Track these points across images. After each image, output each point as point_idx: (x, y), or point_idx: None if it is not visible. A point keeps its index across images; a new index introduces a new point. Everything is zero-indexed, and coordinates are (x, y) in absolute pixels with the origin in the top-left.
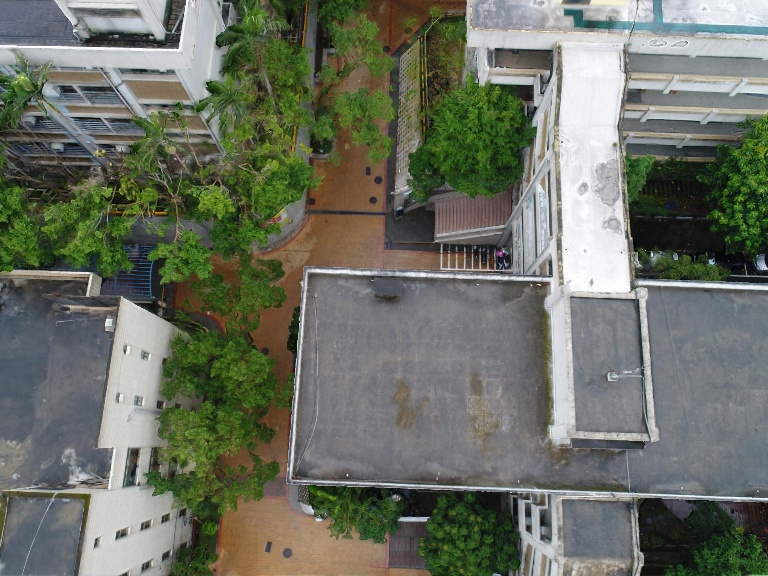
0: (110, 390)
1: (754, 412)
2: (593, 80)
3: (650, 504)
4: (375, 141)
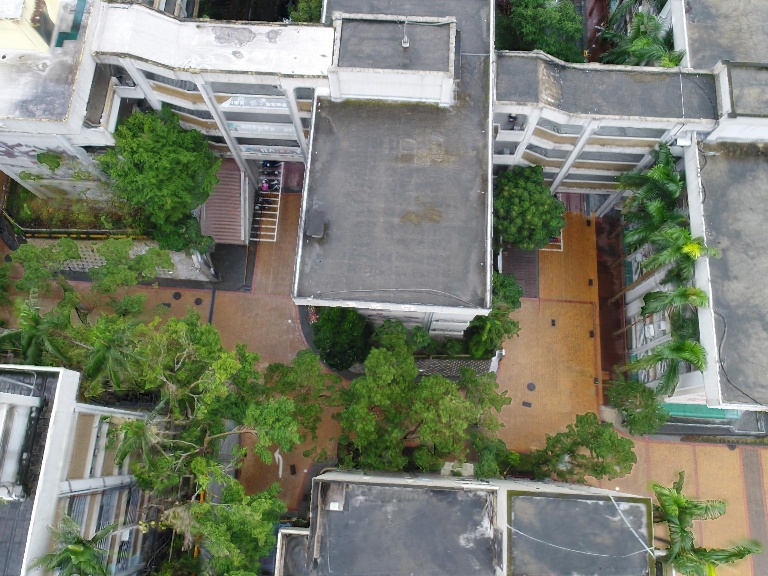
0: None
1: None
2: (135, 31)
3: None
4: None
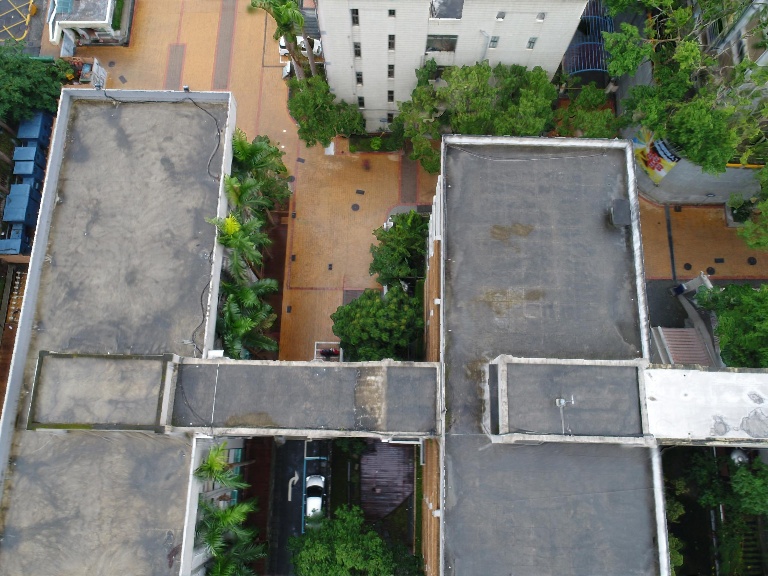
0: (510, 3)
1: (528, 575)
2: None
3: (402, 537)
4: (764, 228)
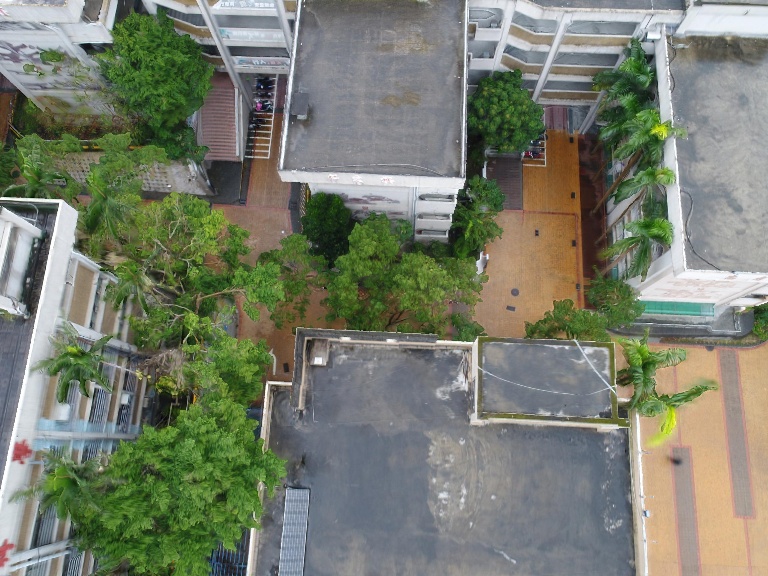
0: None
1: None
2: None
3: None
4: None
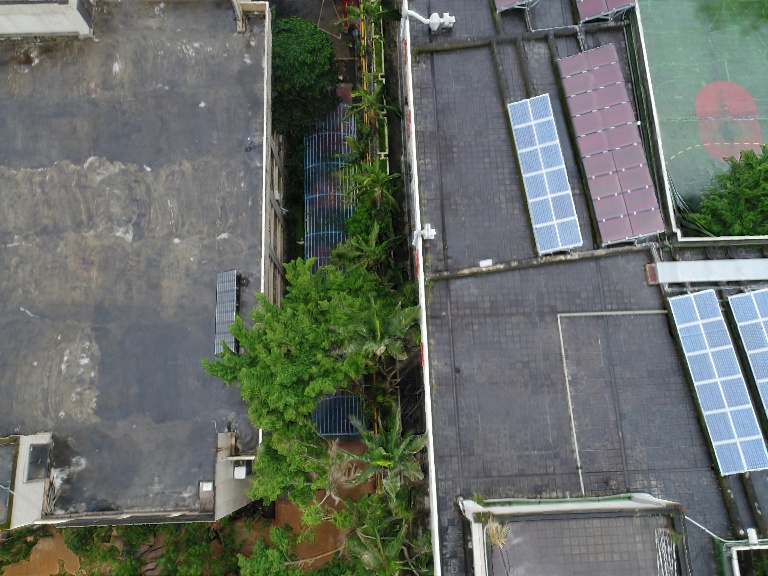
0: None
1: None
2: None
3: None
4: None
